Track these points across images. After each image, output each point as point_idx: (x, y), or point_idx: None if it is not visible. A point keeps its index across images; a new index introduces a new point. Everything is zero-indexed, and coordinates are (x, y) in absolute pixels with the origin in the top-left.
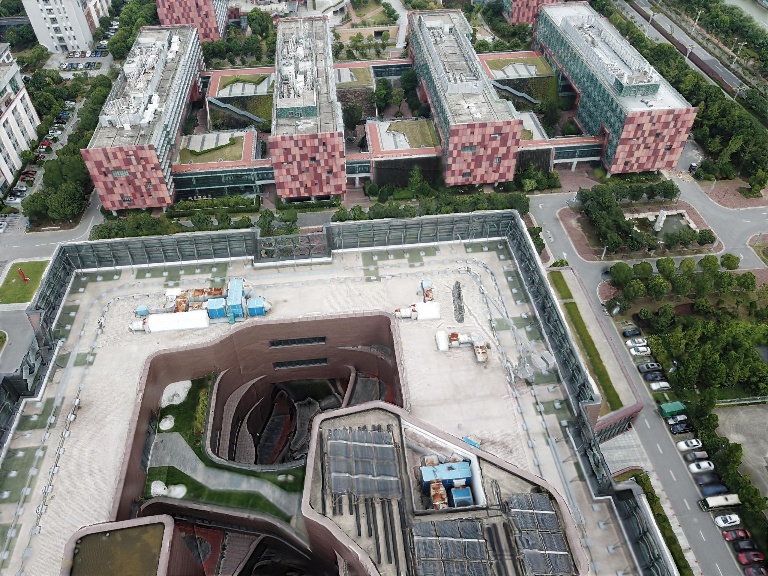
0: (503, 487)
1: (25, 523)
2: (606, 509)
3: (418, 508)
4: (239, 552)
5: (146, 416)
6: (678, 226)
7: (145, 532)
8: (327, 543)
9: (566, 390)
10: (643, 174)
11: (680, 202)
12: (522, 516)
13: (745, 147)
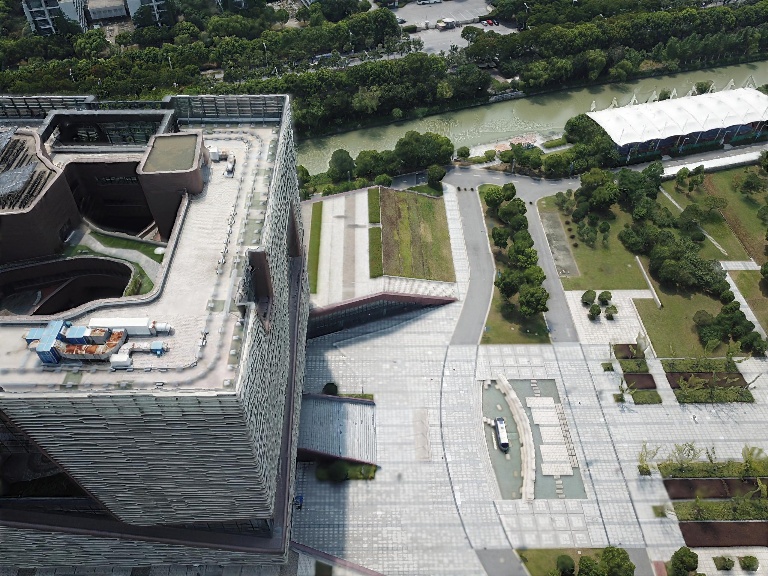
0: None
1: (242, 208)
2: None
3: None
4: None
5: None
6: None
7: None
8: None
9: None
10: None
11: None
12: None
13: None
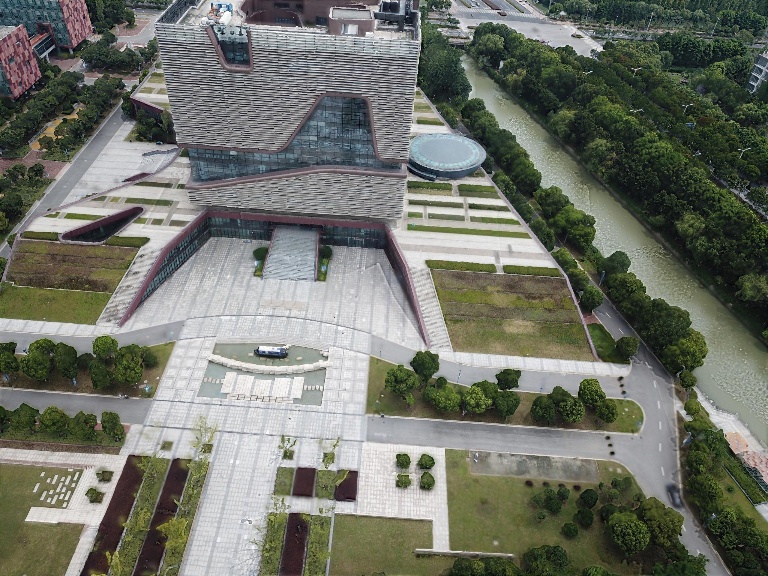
0: None
1: None
2: None
3: None
4: None
5: None
6: (136, 50)
7: None
8: None
9: None
10: (83, 42)
11: (117, 44)
12: None
13: (105, 4)
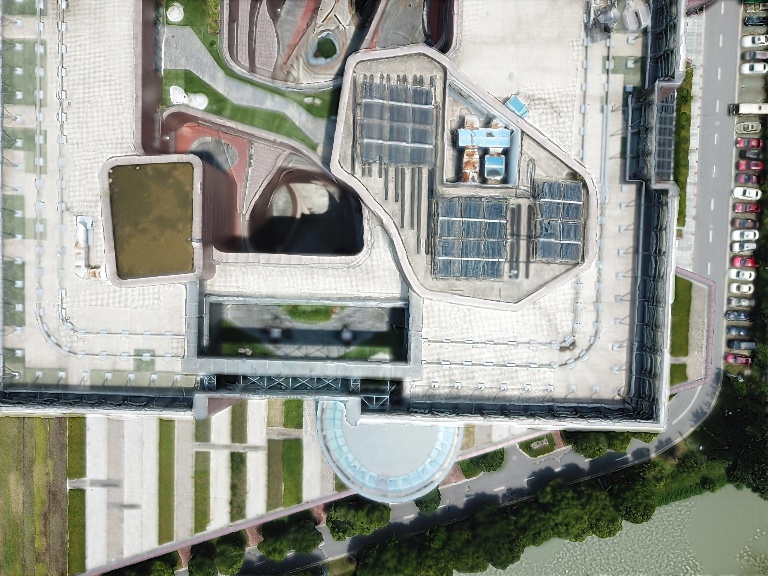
0: (539, 167)
1: (49, 130)
2: (634, 191)
3: (447, 167)
4: (266, 164)
5: (150, 10)
6: None
7: (174, 169)
8: (353, 193)
9: (648, 45)
10: None
11: None
12: (549, 205)
13: None
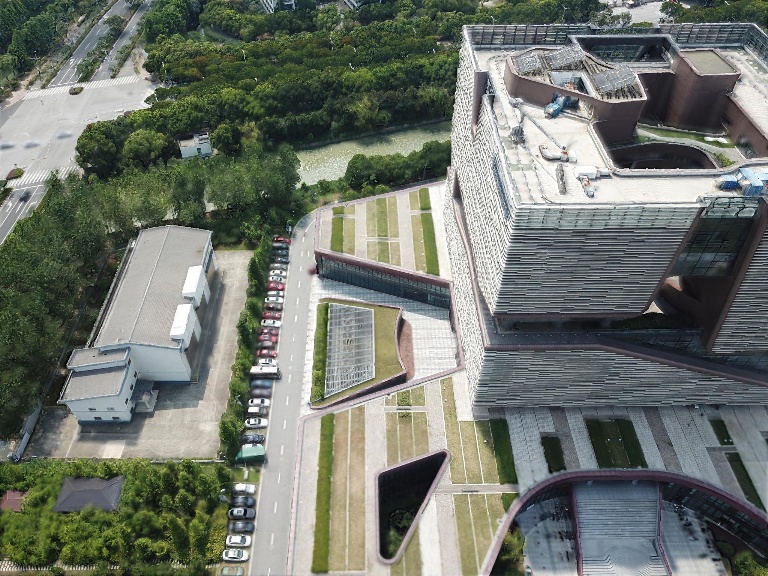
0: (540, 79)
1: None
2: None
3: None
4: None
5: None
6: None
7: None
8: None
9: None
10: None
11: None
12: None
13: None
